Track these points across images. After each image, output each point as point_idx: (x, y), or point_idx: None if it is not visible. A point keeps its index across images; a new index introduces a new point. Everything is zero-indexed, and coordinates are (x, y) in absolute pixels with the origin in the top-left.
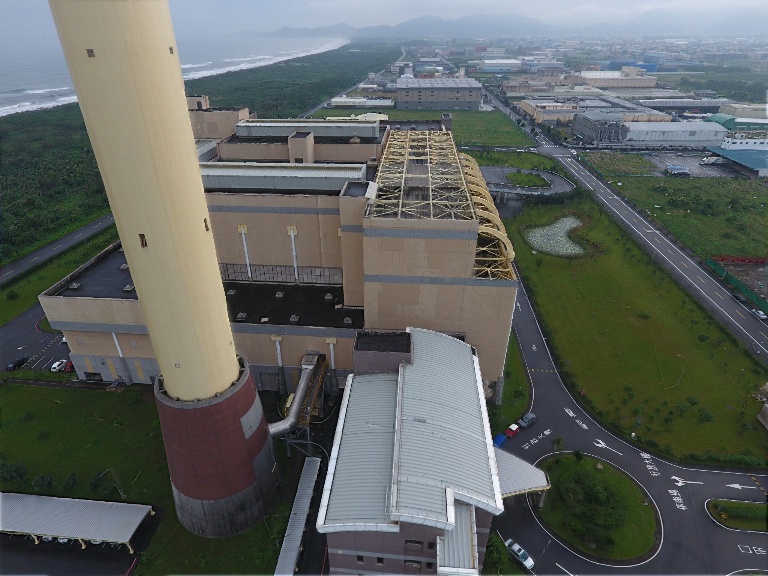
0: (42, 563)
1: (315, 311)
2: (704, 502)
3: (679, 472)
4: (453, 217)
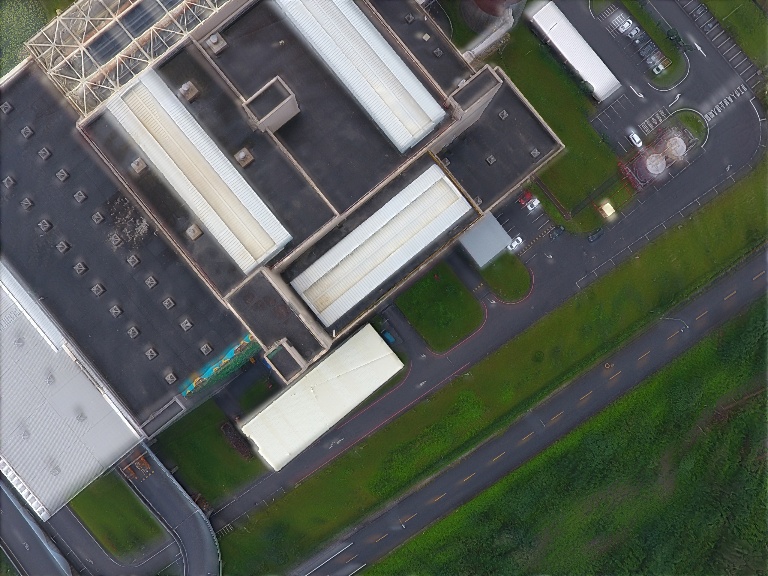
0: (582, 36)
1: (390, 16)
2: None
3: None
4: None
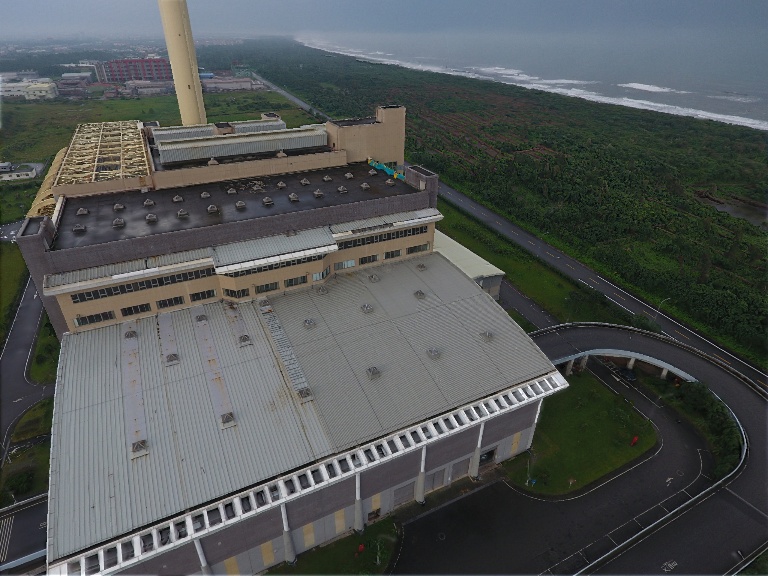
0: None
1: None
2: (1, 234)
3: (1, 239)
4: (91, 124)
